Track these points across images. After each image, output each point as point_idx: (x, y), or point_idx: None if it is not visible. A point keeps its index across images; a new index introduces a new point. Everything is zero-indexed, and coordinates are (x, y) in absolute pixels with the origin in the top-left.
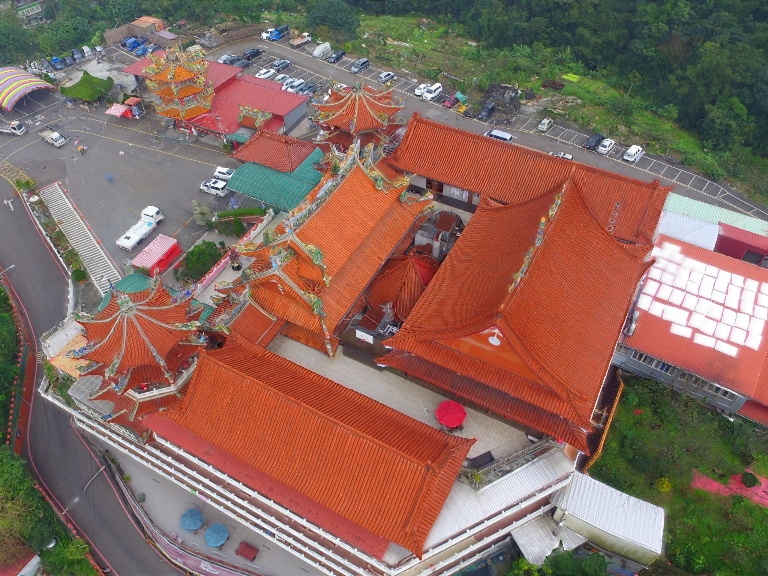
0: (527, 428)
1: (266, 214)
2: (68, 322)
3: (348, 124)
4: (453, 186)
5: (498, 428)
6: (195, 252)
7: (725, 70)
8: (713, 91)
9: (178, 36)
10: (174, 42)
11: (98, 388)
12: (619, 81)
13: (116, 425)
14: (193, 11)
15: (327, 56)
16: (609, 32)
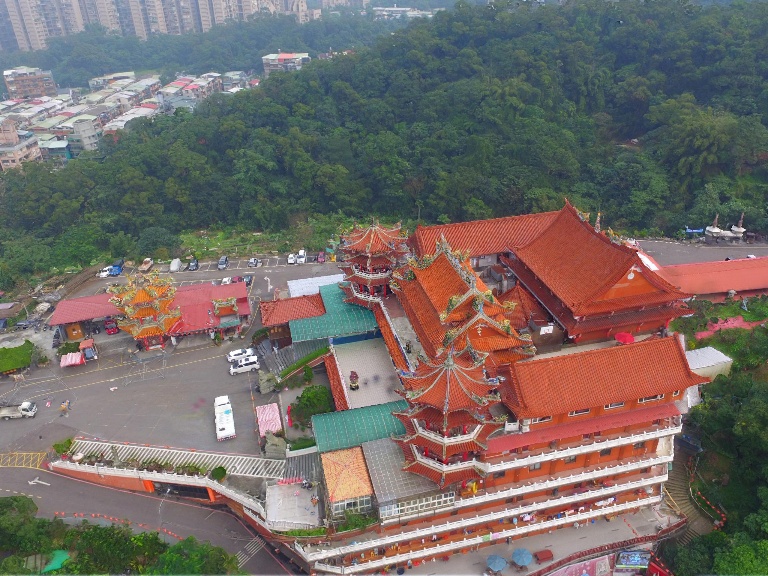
0: (651, 330)
1: (330, 350)
2: (267, 499)
3: (384, 247)
4: (470, 257)
5: (640, 339)
6: (311, 396)
7: (465, 183)
8: (462, 198)
9: (14, 303)
10: (15, 309)
11: (398, 484)
12: (387, 219)
13: (434, 499)
14: (0, 282)
15: (183, 268)
16: (359, 193)
